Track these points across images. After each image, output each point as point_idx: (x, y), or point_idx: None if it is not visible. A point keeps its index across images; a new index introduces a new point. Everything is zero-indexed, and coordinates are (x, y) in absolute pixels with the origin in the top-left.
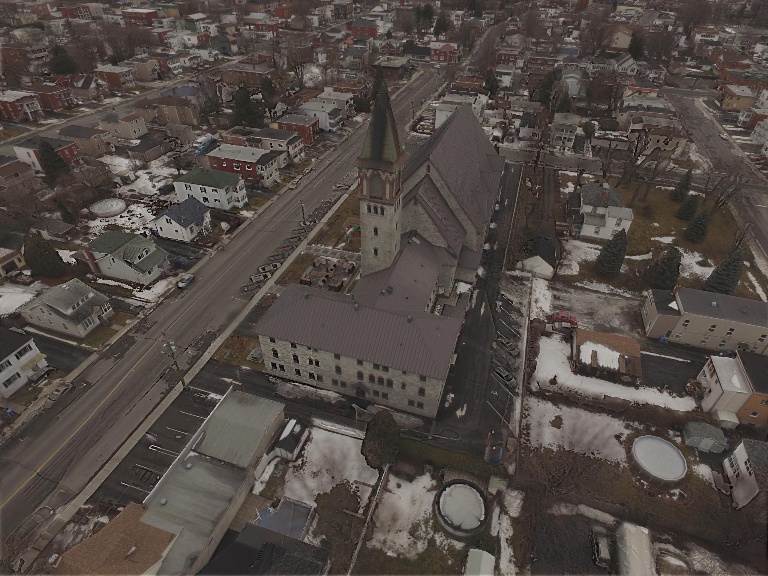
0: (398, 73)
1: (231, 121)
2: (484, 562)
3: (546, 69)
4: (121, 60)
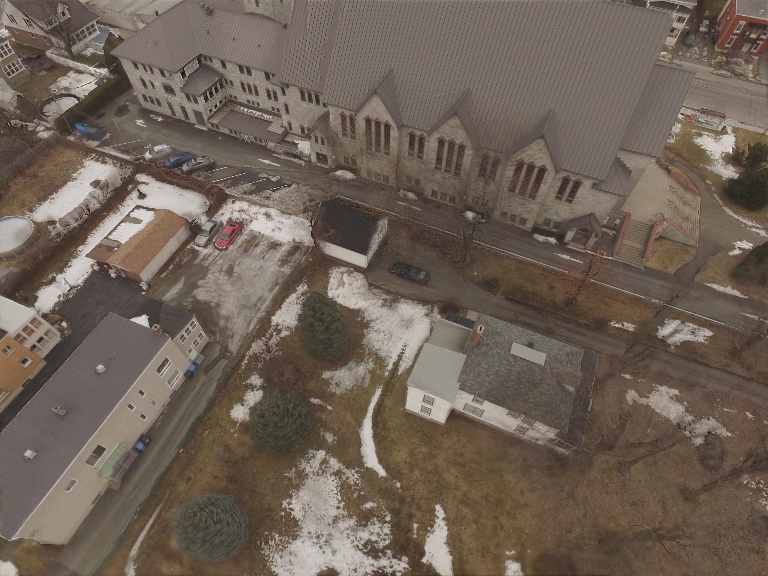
0: None
1: None
2: (7, 94)
3: None
4: None
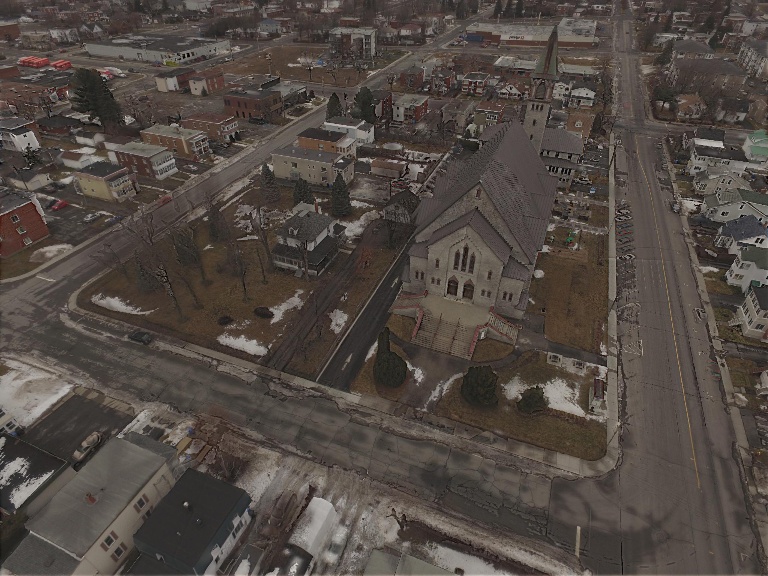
0: None
1: None
2: None
3: None
4: None
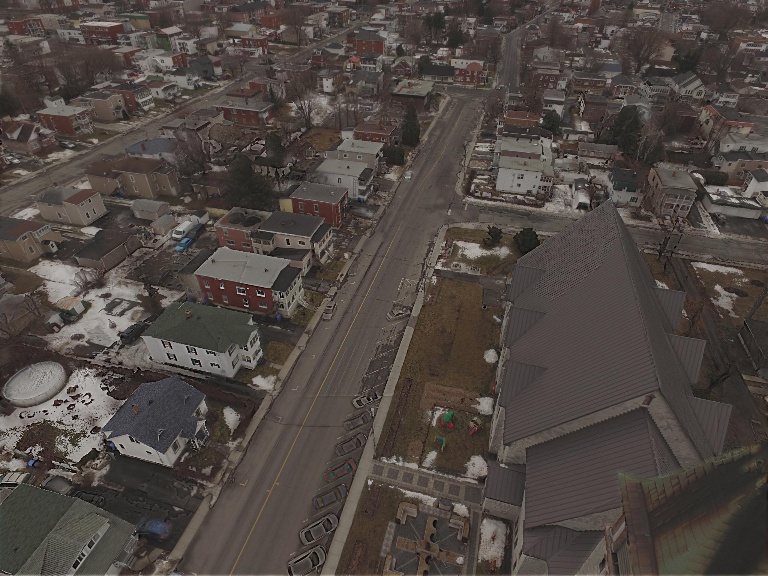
0: (424, 103)
1: (226, 200)
2: None
3: (594, 92)
4: (75, 93)
